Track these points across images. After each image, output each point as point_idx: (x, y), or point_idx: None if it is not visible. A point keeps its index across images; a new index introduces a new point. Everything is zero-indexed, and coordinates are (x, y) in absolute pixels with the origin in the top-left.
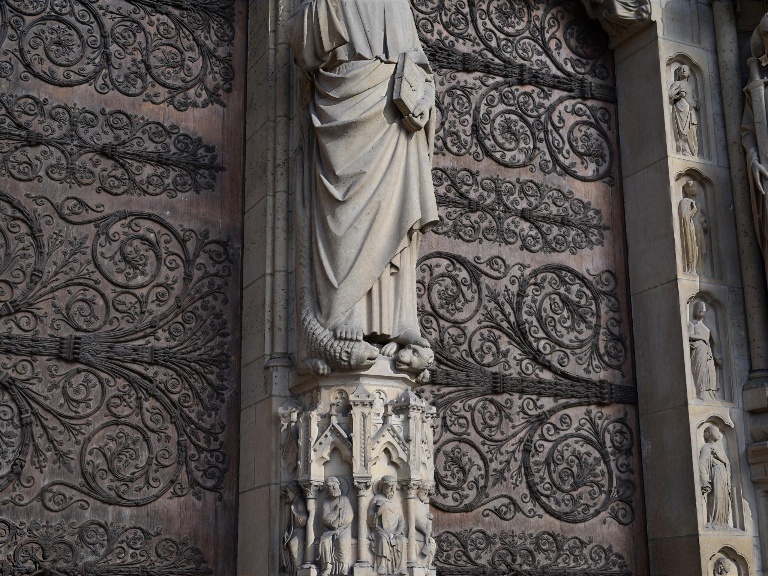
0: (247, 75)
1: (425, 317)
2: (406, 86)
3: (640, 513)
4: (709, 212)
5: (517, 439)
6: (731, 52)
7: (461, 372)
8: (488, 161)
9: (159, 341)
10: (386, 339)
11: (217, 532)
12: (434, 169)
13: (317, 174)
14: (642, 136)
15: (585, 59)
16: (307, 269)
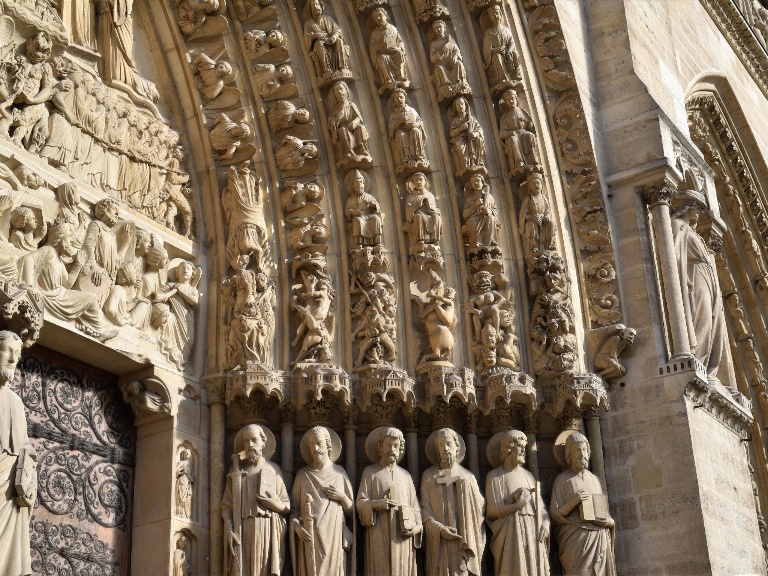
0: None
1: None
2: (24, 475)
3: None
4: (193, 560)
5: None
6: (220, 444)
7: None
8: (42, 508)
9: None
10: None
11: None
12: None
13: None
14: (152, 498)
15: (117, 432)
16: None
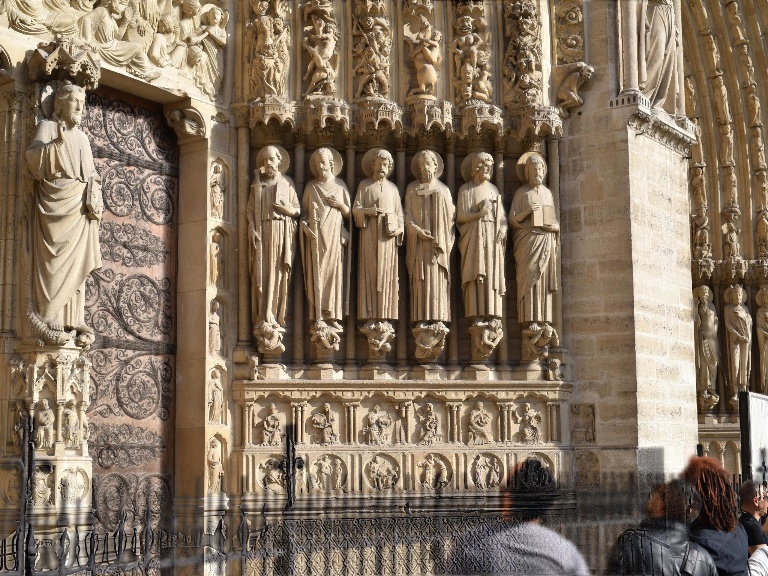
0: None
1: None
2: (93, 197)
3: (172, 414)
4: (225, 251)
5: (113, 373)
6: (246, 160)
7: None
8: (108, 212)
9: None
10: (71, 328)
11: None
12: None
13: (41, 238)
14: (193, 203)
15: (164, 150)
16: (30, 288)
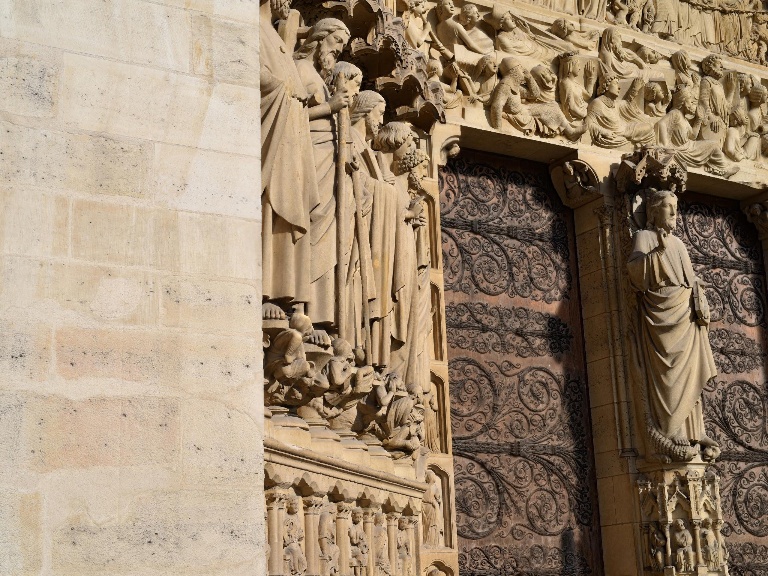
0: (580, 279)
1: None
2: (700, 302)
3: None
4: None
5: (729, 488)
6: None
7: None
8: None
9: (554, 441)
10: (695, 442)
11: (592, 549)
12: None
13: (653, 351)
14: None
15: (746, 248)
16: (647, 403)
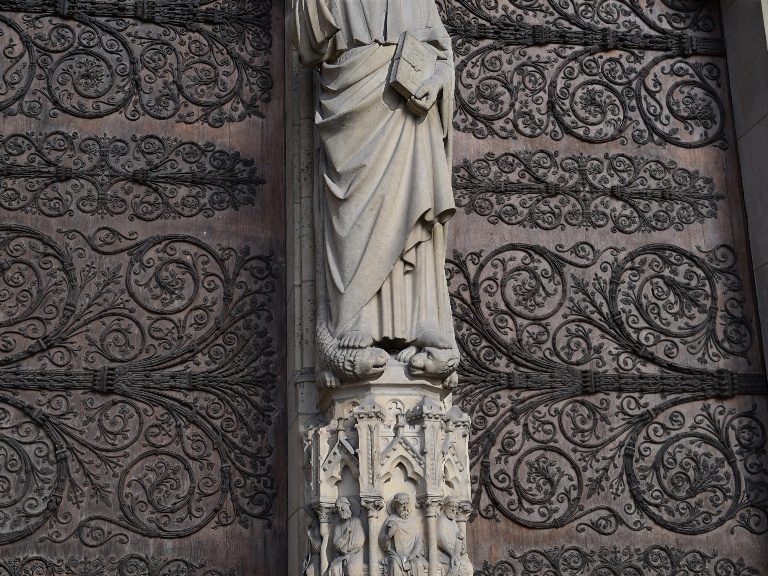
0: (285, 82)
1: (499, 316)
2: (405, 67)
3: None
4: None
5: (616, 443)
6: None
7: (544, 373)
8: (569, 139)
9: (199, 366)
10: (403, 343)
11: (267, 561)
12: (504, 155)
13: None
14: (751, 88)
15: (684, 12)
16: (322, 276)
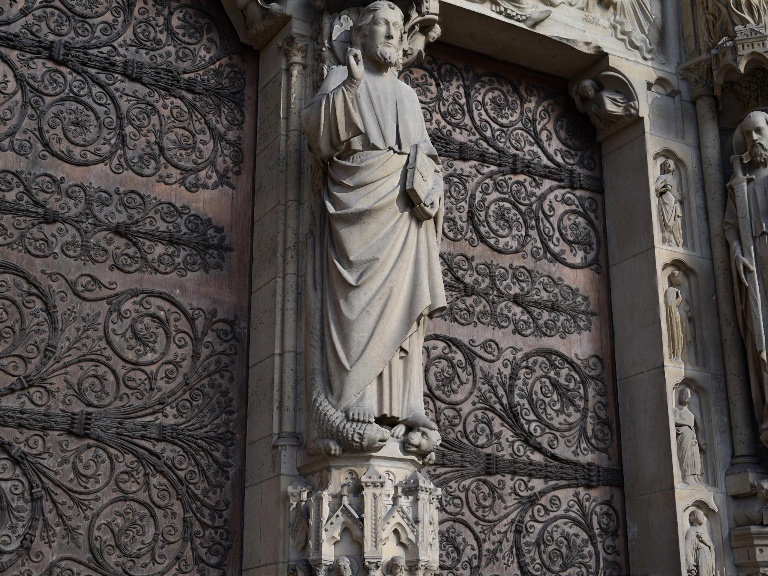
0: (256, 159)
1: None
2: (418, 176)
3: None
4: (693, 301)
5: (509, 520)
6: (714, 149)
7: (456, 453)
8: (483, 247)
9: (167, 418)
10: (395, 421)
11: None
12: None
13: (330, 259)
14: (629, 226)
15: (574, 150)
16: (318, 351)
